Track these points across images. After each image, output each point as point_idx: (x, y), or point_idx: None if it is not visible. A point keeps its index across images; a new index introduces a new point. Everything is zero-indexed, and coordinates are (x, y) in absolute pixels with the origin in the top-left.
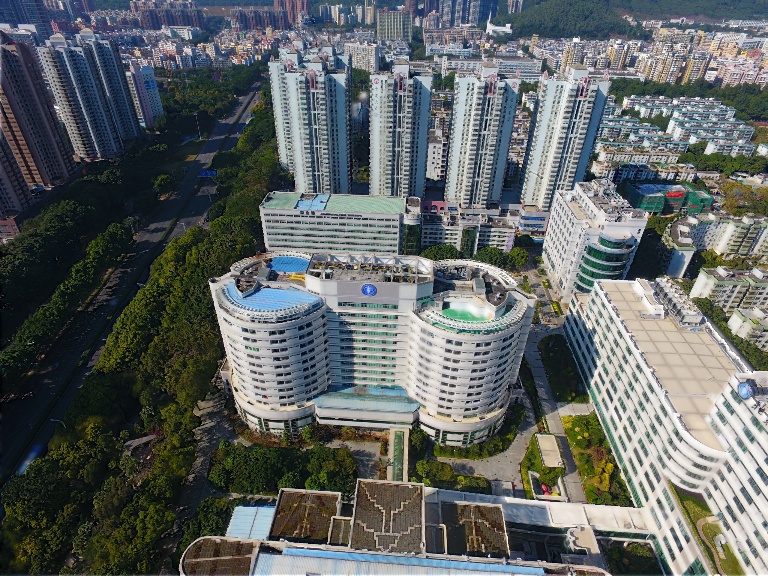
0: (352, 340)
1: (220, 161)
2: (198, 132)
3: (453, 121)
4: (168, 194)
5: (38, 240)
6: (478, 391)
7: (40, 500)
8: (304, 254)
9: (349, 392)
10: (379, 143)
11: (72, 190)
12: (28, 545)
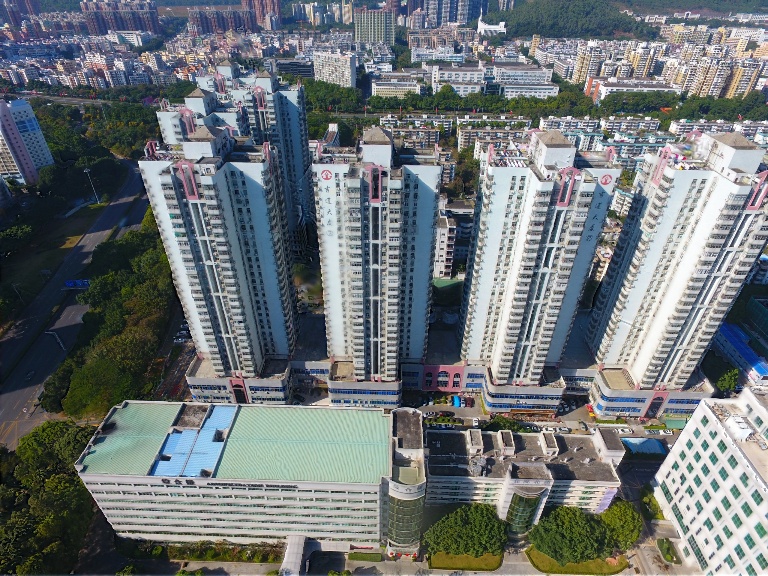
0: None
1: (100, 260)
2: (94, 194)
3: (480, 242)
4: (3, 328)
5: None
6: None
7: None
8: None
9: None
10: (339, 279)
11: None
12: None
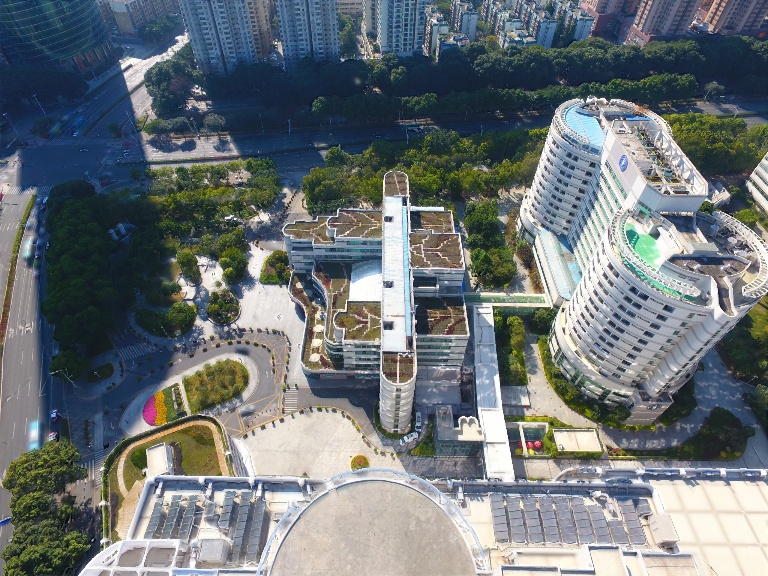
0: (593, 207)
1: None
2: None
3: None
4: None
5: (631, 53)
6: (588, 319)
7: (434, 143)
8: (667, 130)
9: (563, 249)
10: None
11: (720, 41)
12: (412, 151)
